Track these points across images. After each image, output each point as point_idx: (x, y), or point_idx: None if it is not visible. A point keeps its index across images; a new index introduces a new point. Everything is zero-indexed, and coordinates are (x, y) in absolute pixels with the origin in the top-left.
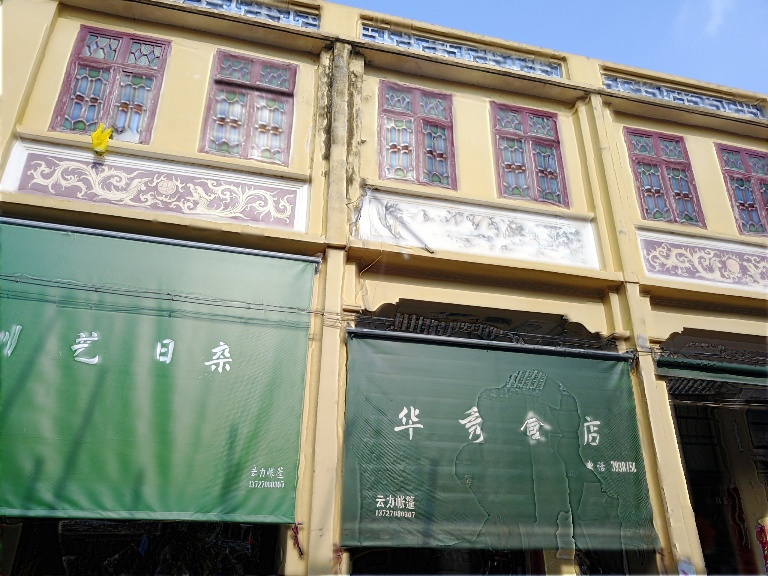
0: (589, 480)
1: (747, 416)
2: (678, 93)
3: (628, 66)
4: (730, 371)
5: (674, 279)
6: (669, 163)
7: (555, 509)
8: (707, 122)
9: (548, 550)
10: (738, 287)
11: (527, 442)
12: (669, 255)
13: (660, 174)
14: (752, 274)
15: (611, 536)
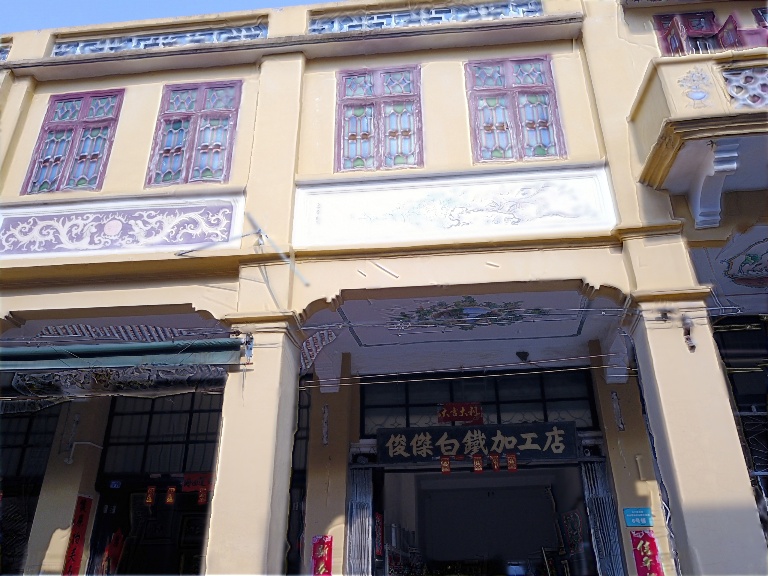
0: (136, 491)
1: (363, 399)
2: (155, 39)
3: (88, 27)
4: (6, 357)
5: (20, 257)
6: (89, 124)
7: (52, 526)
8: (151, 65)
9: (30, 572)
10: (104, 252)
11: (47, 453)
12: (32, 230)
13: (71, 139)
14: (135, 233)
15: (140, 554)
